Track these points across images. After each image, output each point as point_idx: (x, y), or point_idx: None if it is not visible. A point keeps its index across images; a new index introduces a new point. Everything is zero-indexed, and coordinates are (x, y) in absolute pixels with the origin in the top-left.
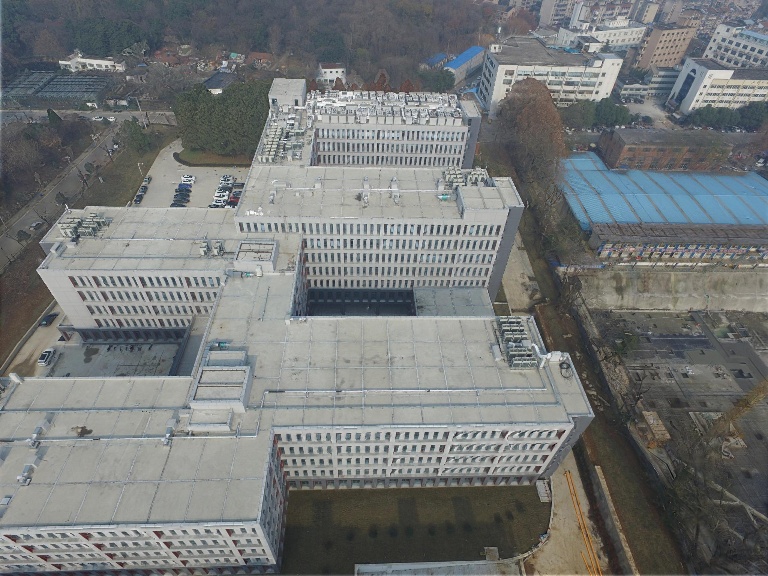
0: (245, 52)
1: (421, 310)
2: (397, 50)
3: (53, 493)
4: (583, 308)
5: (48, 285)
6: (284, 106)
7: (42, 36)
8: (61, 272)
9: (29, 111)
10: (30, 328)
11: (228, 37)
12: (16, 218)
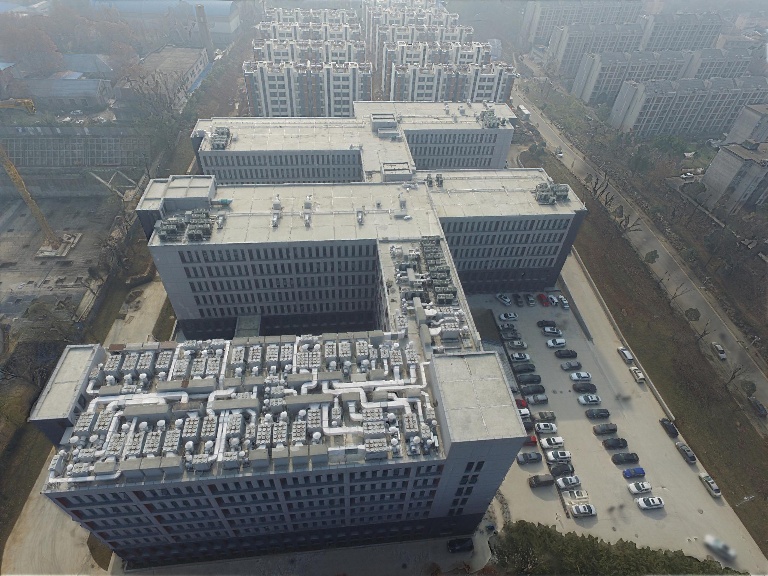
0: None
1: None
2: None
3: None
4: (86, 299)
5: None
6: None
7: None
8: None
9: None
10: None
11: None
12: (764, 367)
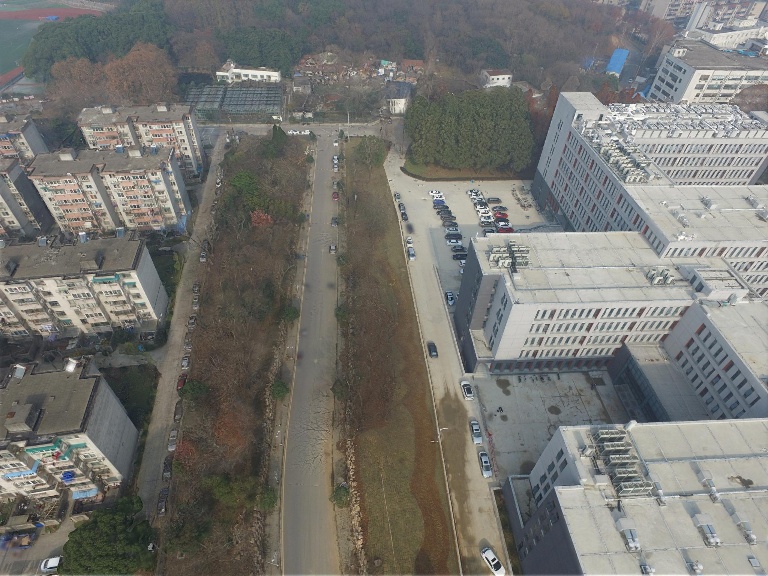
0: (399, 59)
1: None
2: (560, 55)
3: None
4: None
5: (510, 319)
6: (590, 121)
7: (201, 47)
8: (535, 306)
9: (217, 125)
10: (425, 360)
11: (380, 44)
12: (304, 241)
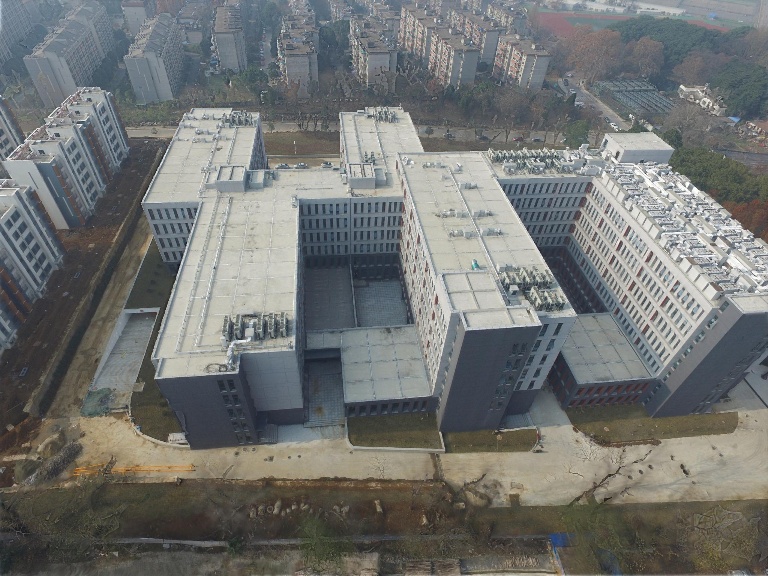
0: None
1: (384, 331)
2: None
3: (186, 149)
4: None
5: None
6: (606, 151)
7: (692, 61)
8: None
9: (596, 100)
10: None
11: None
12: (455, 128)
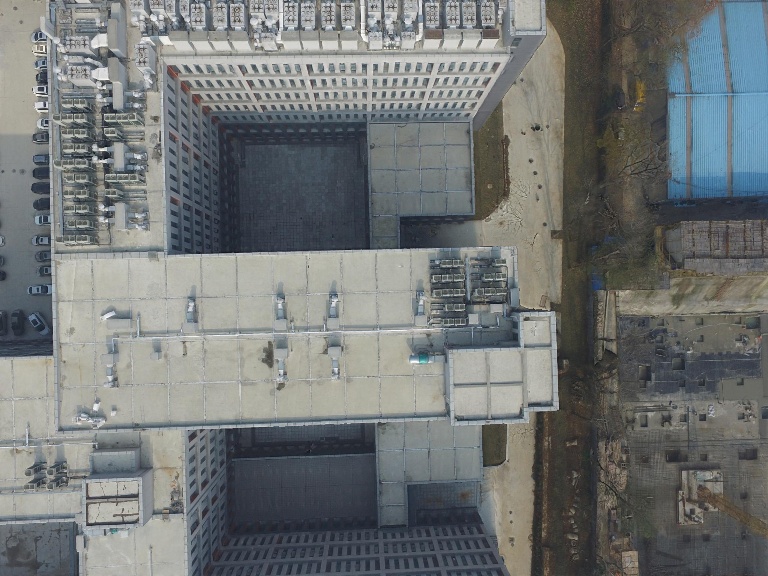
0: None
1: (383, 429)
2: None
3: None
4: (613, 351)
5: None
6: None
7: None
8: None
9: None
10: None
11: None
12: None
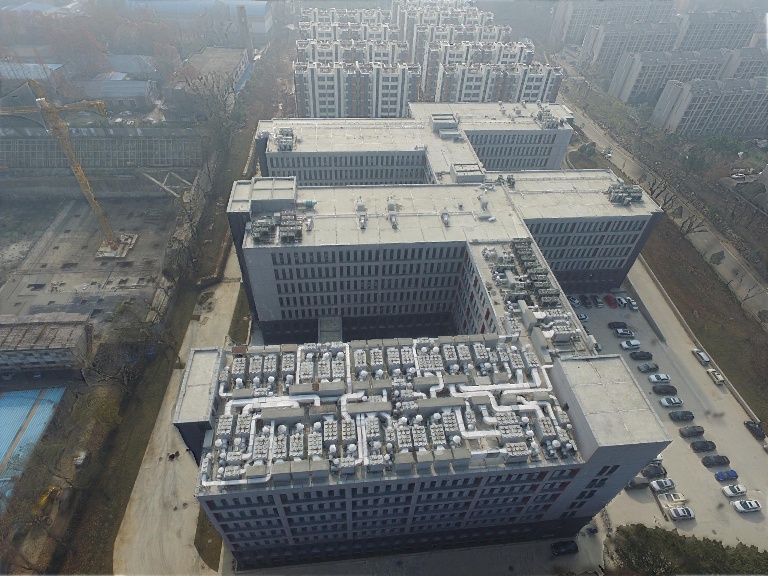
0: None
1: None
2: None
3: (488, 108)
4: None
5: None
6: None
7: None
8: None
9: None
10: None
11: None
12: None
